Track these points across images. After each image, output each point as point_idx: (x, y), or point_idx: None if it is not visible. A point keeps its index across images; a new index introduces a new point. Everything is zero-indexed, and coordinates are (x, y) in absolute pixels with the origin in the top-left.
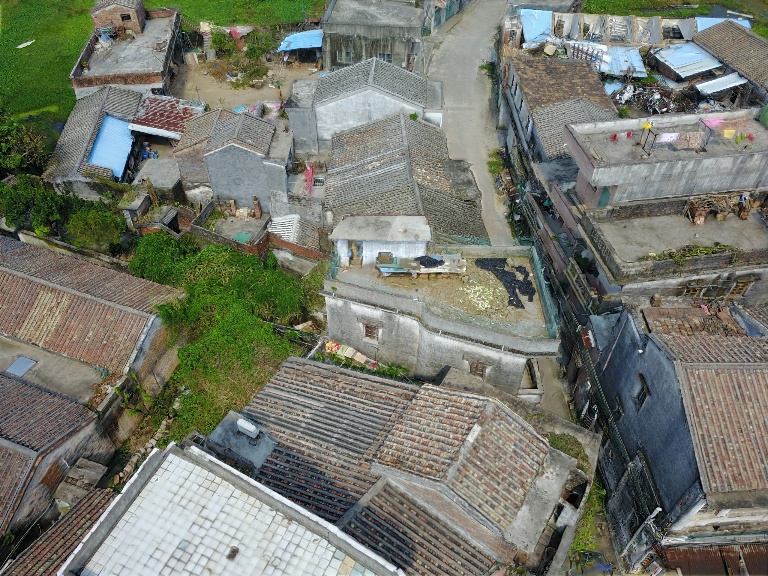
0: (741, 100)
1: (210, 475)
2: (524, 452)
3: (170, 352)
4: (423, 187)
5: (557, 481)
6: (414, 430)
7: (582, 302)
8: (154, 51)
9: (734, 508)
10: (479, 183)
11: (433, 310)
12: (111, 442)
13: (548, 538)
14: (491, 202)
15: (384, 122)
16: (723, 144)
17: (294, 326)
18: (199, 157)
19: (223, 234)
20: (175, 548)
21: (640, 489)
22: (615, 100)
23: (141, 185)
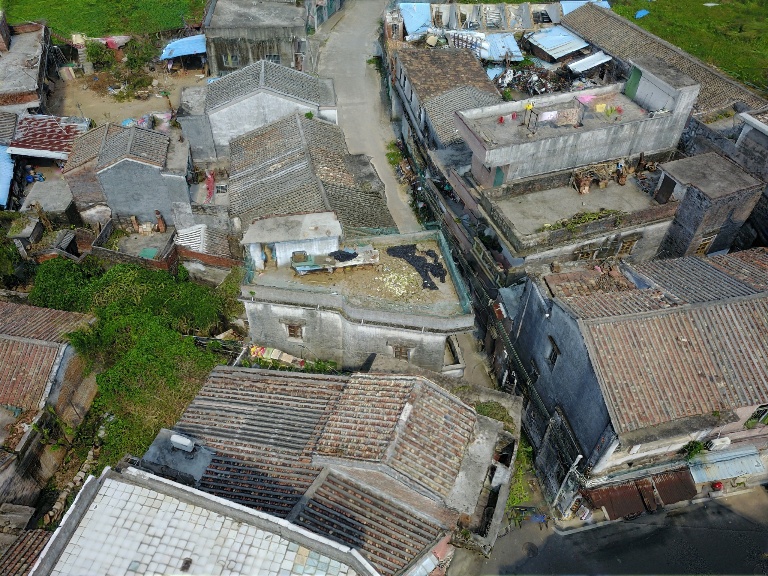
0: (608, 76)
1: (152, 493)
2: (454, 423)
3: (87, 380)
4: (327, 184)
5: (487, 444)
6: (349, 418)
7: (490, 277)
8: (25, 68)
9: (642, 443)
10: (381, 175)
11: (352, 302)
12: (35, 482)
13: (486, 499)
14: (394, 192)
15: (280, 123)
16: (597, 118)
17: (215, 336)
18: (91, 176)
19: (128, 252)
20: (125, 571)
21: (562, 441)
22: (497, 85)
23: (30, 211)
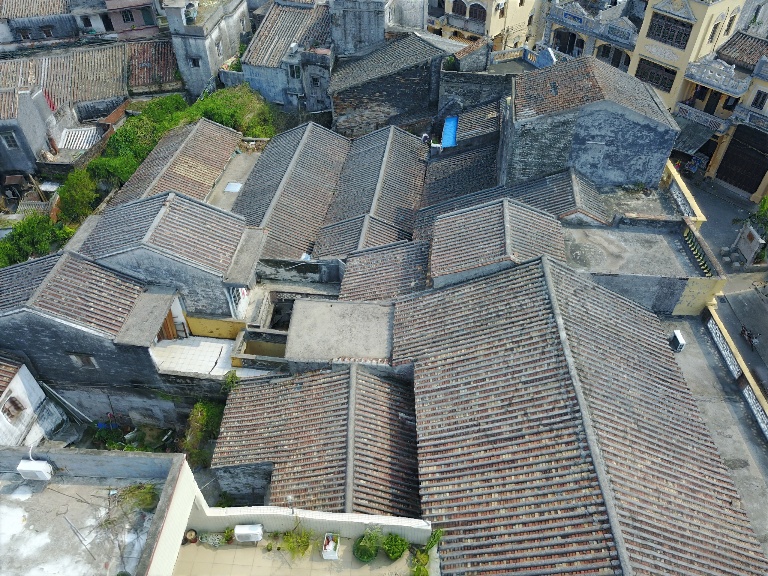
0: None
1: None
2: None
3: None
4: None
5: None
6: None
7: None
8: None
9: None
10: None
11: None
12: None
13: None
14: None
15: None
16: None
17: None
18: None
19: None
20: None
21: None
22: None
23: None
